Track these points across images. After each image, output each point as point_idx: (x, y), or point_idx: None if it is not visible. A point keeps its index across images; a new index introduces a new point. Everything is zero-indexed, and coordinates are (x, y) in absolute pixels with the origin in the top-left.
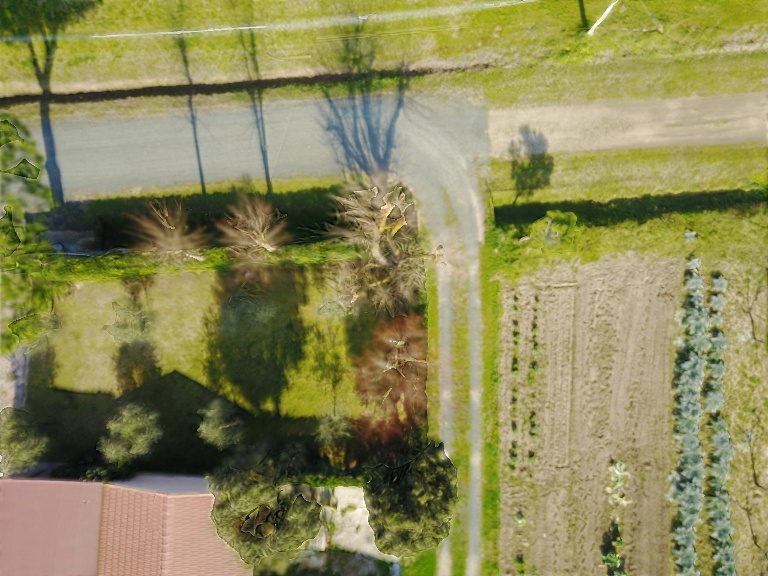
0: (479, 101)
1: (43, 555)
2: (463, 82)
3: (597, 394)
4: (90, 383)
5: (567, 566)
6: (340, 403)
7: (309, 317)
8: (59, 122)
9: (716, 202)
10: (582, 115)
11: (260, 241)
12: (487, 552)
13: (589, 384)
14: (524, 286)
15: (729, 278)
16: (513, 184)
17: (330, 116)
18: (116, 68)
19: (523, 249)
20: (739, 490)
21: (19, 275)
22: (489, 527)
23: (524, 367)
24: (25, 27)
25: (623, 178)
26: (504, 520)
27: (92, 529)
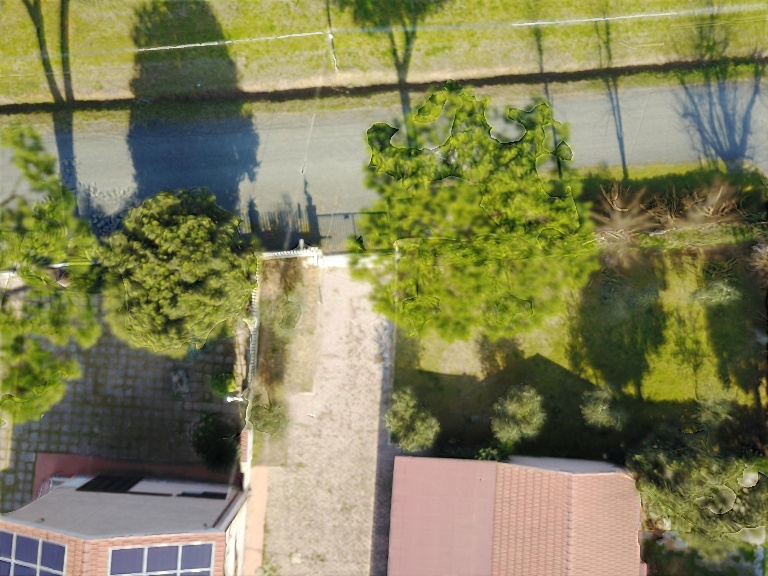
0: None
1: (442, 530)
2: None
3: None
4: (455, 365)
5: None
6: (702, 386)
7: (669, 301)
8: None
9: None
10: None
11: (672, 225)
12: None
13: None
14: None
15: None
16: None
17: (686, 103)
18: (472, 57)
19: None
20: None
21: (385, 259)
22: None
23: None
24: (386, 18)
25: None
26: None
27: (488, 506)
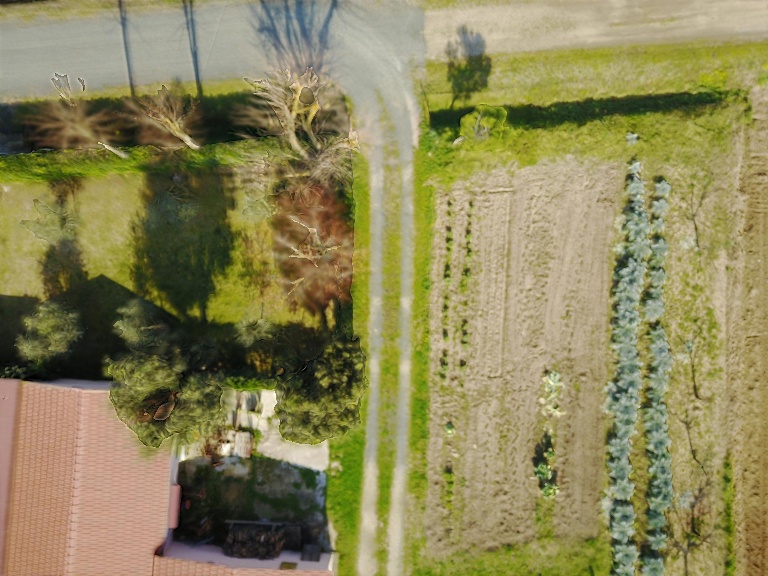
0: (414, 0)
1: None
2: None
3: (532, 303)
4: (17, 286)
5: (498, 478)
6: (268, 309)
7: (237, 221)
8: None
9: (661, 105)
10: (521, 14)
11: (174, 130)
12: (416, 462)
13: (524, 292)
14: (458, 191)
15: (672, 183)
16: (449, 87)
17: (261, 16)
18: None
19: (457, 152)
20: (678, 403)
21: None
22: (418, 437)
23: (457, 274)
24: None
25: (563, 80)
26: (434, 430)
27: (10, 425)
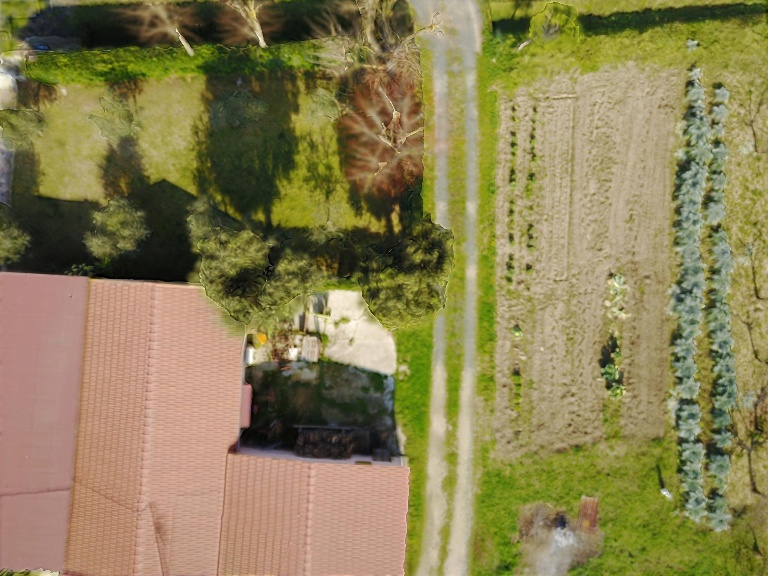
0: None
1: (27, 349)
2: None
3: (596, 207)
4: (77, 191)
5: (565, 380)
6: (334, 214)
7: (302, 127)
8: None
9: (718, 15)
10: None
11: (252, 19)
12: (483, 365)
13: (588, 197)
14: (522, 97)
15: (731, 90)
16: None
17: None
18: None
19: (522, 58)
20: (740, 304)
21: (4, 80)
22: (486, 340)
23: (522, 179)
24: None
25: None
26: (501, 333)
27: (78, 323)
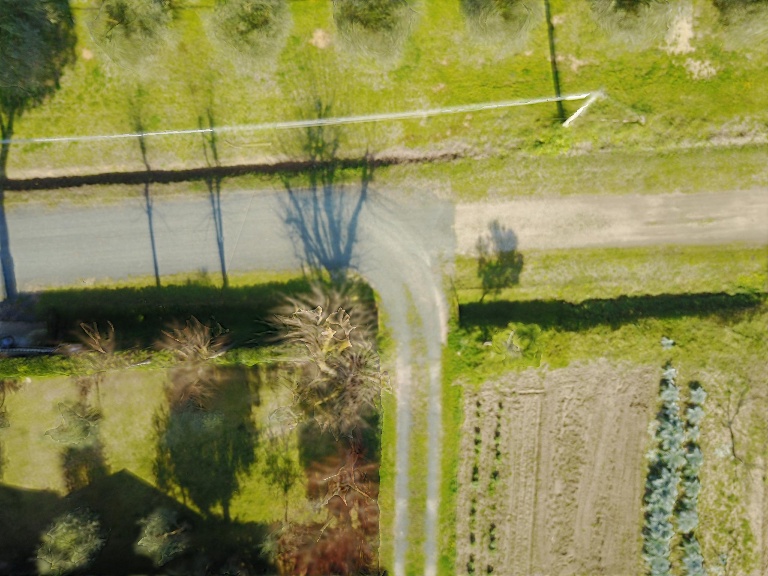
0: (445, 194)
1: None
2: (429, 173)
3: (562, 508)
4: (40, 479)
5: None
6: (292, 508)
7: (262, 417)
8: (14, 210)
9: (697, 307)
10: (555, 211)
11: (202, 355)
12: None
13: (554, 497)
14: (488, 391)
15: (708, 390)
16: (479, 282)
17: (289, 207)
18: (72, 154)
19: (487, 353)
20: None
21: None
22: None
23: (485, 477)
24: None
25: (597, 279)
26: None
27: None
